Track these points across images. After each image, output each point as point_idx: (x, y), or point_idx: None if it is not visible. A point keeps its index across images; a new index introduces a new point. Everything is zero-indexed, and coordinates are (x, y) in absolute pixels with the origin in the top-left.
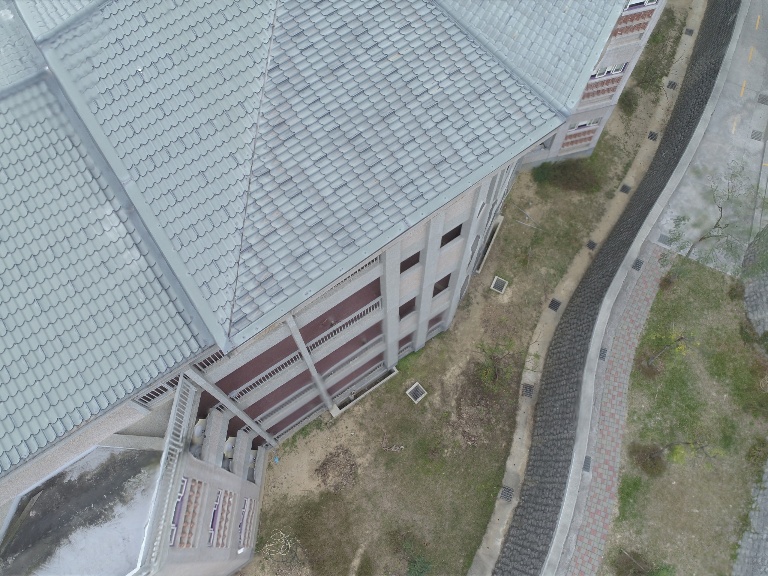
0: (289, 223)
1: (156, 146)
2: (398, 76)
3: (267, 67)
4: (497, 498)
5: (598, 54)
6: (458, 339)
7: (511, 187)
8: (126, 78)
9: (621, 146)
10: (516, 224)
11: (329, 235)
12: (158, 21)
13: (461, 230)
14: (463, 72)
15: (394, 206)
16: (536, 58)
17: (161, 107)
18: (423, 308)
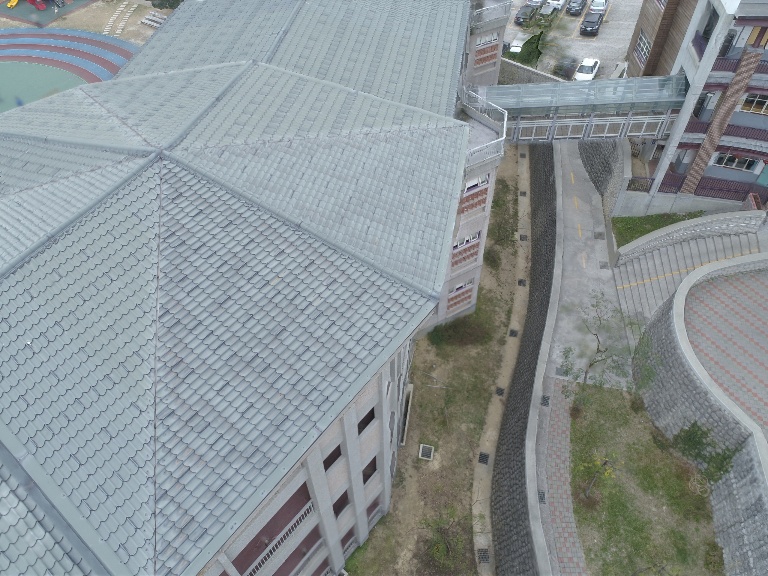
0: (202, 458)
1: (53, 413)
2: (282, 296)
3: (157, 314)
4: None
5: (449, 242)
6: (401, 520)
7: (412, 356)
8: (15, 353)
9: (498, 297)
10: (426, 388)
11: (244, 460)
12: (44, 294)
13: (374, 413)
14: (339, 281)
15: (303, 415)
16: (399, 256)
17: (54, 374)
18: (357, 499)
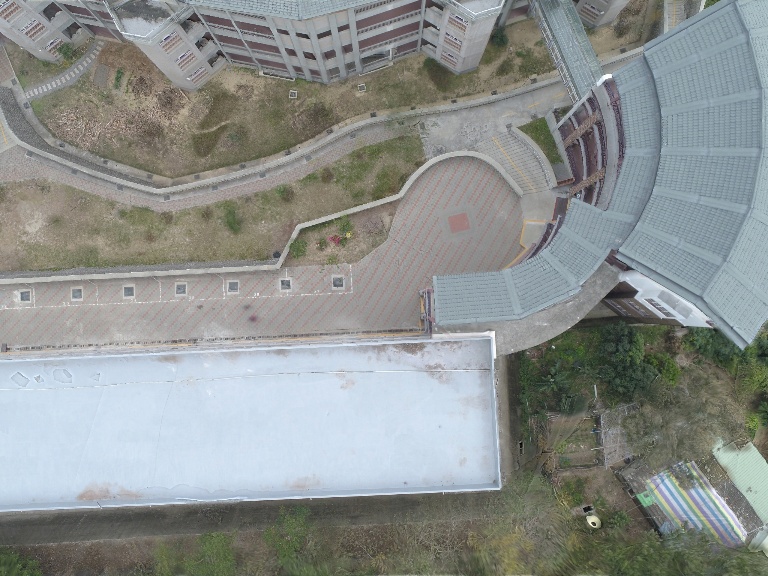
0: None
1: None
2: None
3: None
4: (283, 151)
5: None
6: (326, 91)
7: (401, 54)
8: None
9: (476, 84)
10: (396, 72)
11: None
12: None
13: (309, 37)
14: None
15: (245, 4)
16: None
17: None
18: (300, 58)
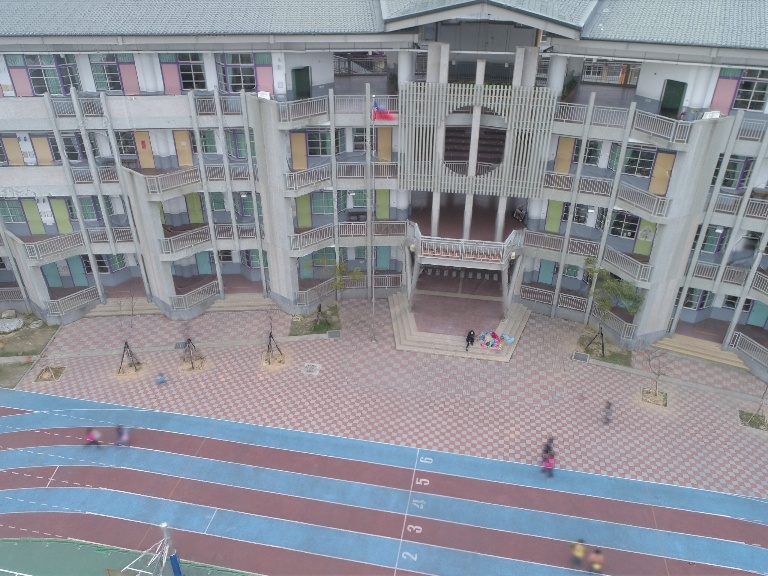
0: None
1: None
2: None
3: None
4: None
5: None
6: None
7: None
8: None
9: None
10: None
11: None
12: None
13: None
14: None
15: None
16: None
17: None
18: None
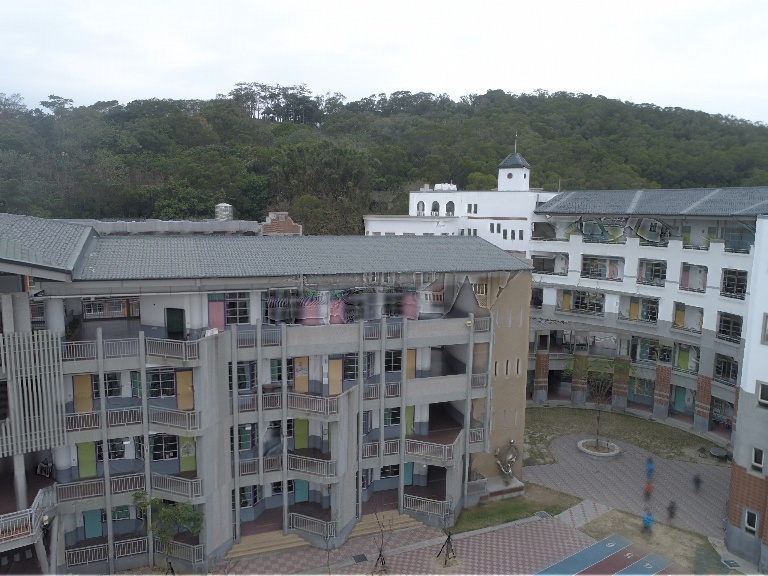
0: None
1: None
2: None
3: None
4: None
5: None
6: None
7: None
8: None
9: None
10: None
11: None
12: None
13: None
14: None
15: None
16: None
17: None
18: None
